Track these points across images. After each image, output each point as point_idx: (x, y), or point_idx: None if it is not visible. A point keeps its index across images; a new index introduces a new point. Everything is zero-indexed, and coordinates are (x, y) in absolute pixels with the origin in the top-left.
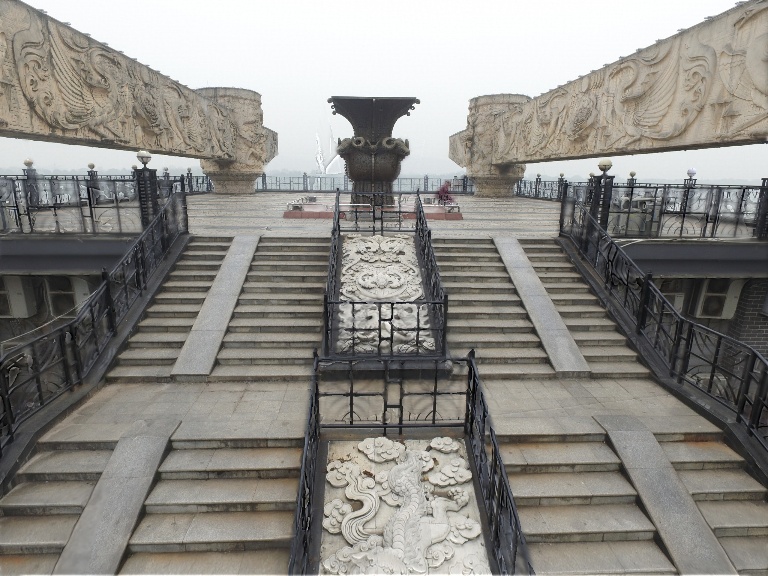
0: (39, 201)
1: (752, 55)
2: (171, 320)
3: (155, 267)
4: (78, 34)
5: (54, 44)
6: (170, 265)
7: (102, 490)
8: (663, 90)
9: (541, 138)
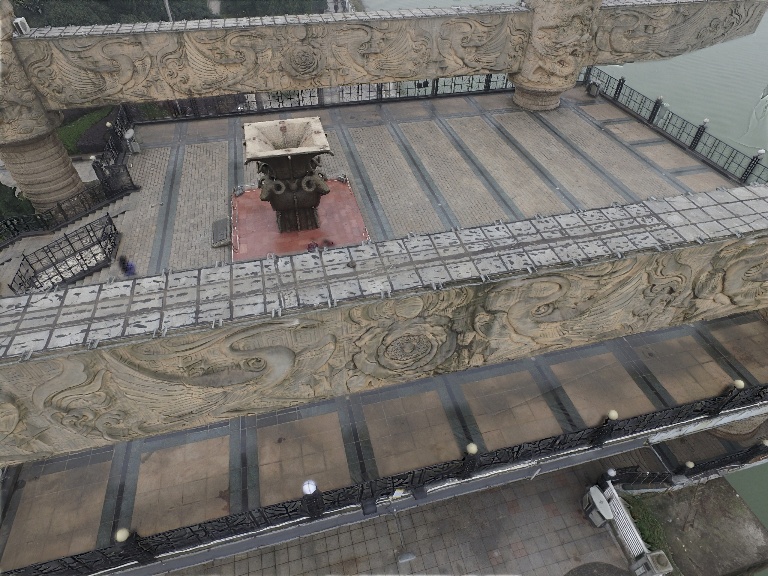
0: (263, 107)
1: None
2: (78, 226)
3: (98, 202)
4: (214, 30)
5: (189, 46)
6: (105, 203)
7: (3, 257)
8: None
9: None
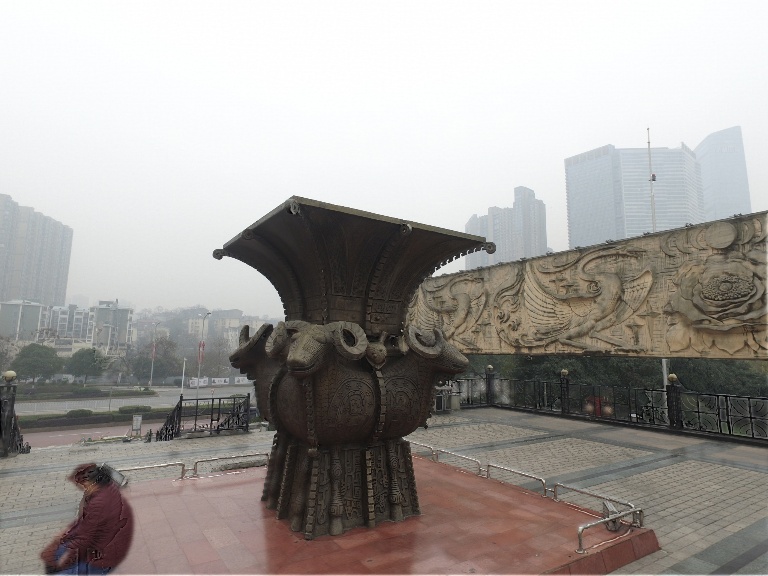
0: (681, 423)
1: None
2: None
3: None
4: (566, 253)
5: None
6: None
7: None
8: None
9: None
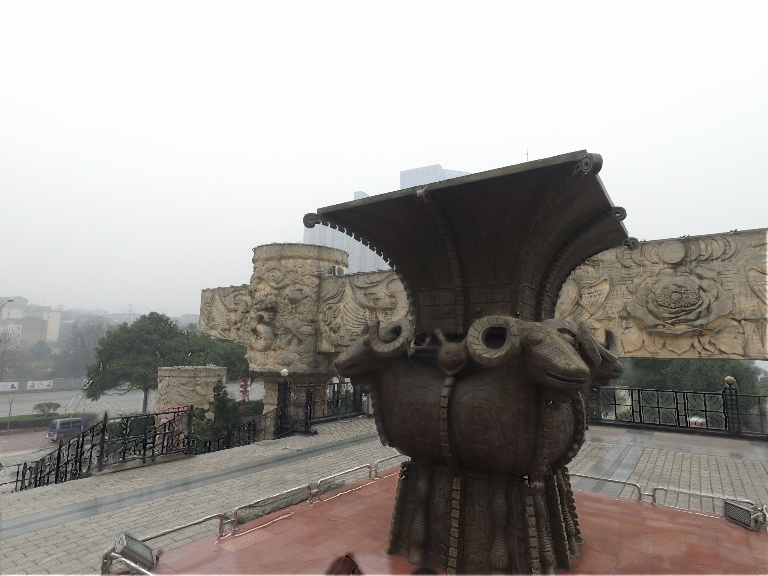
0: (600, 415)
1: None
2: None
3: None
4: None
5: None
6: None
7: None
8: None
9: None
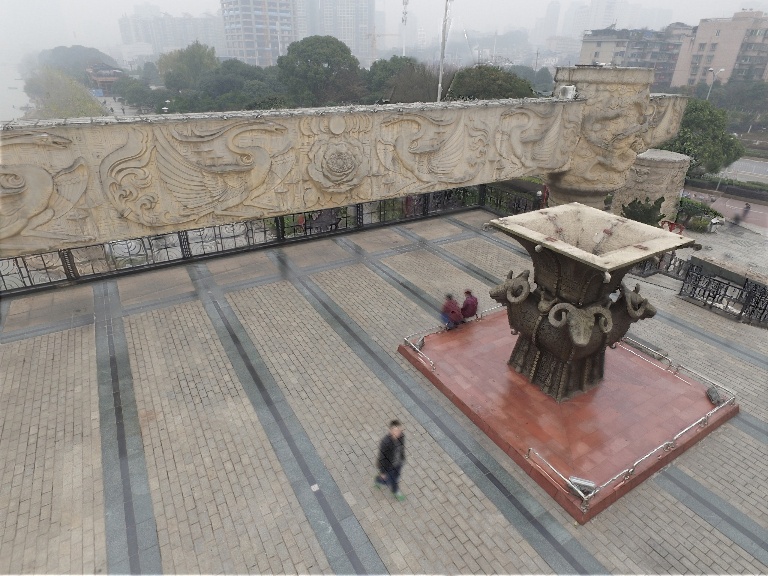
0: None
1: (514, 137)
2: None
3: None
4: None
5: None
6: None
7: None
8: (454, 147)
9: (219, 193)
